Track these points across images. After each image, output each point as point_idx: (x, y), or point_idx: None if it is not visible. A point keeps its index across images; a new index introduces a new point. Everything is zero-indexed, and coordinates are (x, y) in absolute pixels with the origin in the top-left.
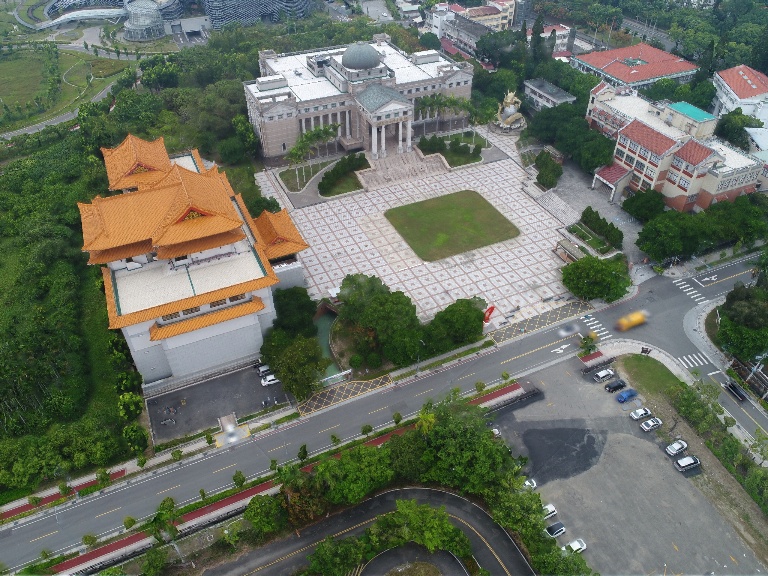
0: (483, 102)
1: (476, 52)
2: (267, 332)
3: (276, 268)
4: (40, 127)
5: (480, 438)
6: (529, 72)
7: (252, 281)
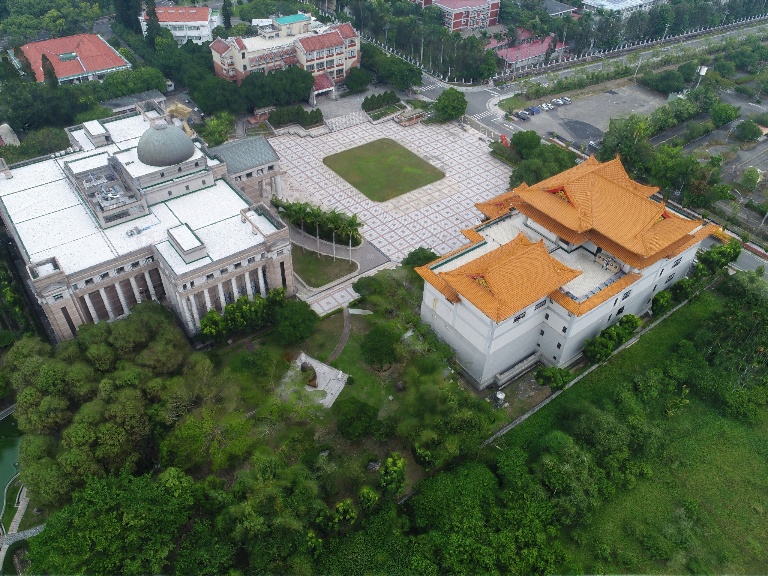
0: None
1: (19, 126)
2: None
3: None
4: None
5: (634, 117)
6: (71, 109)
7: None
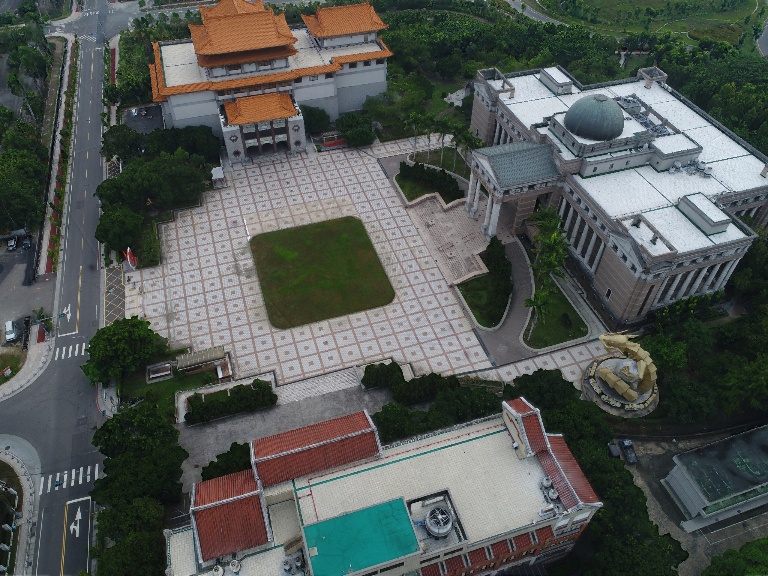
0: (663, 337)
1: None
2: None
3: (221, 117)
4: None
5: None
6: None
7: None
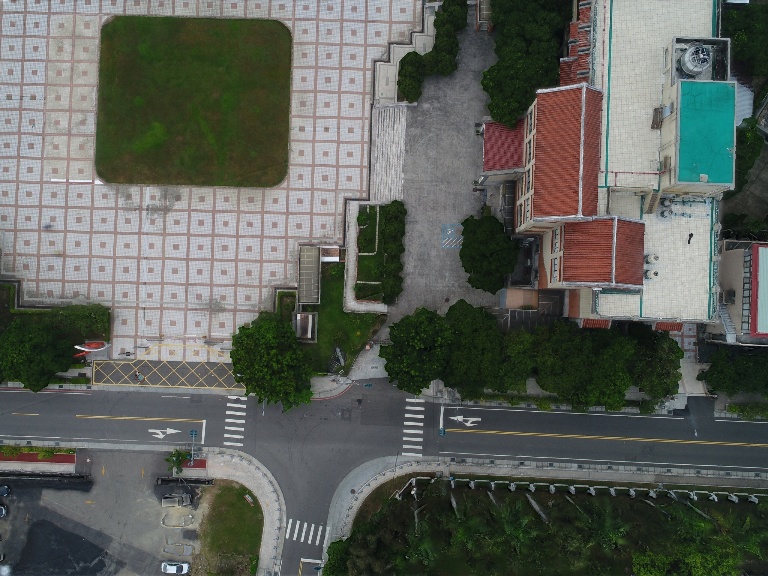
0: None
1: None
2: None
3: None
4: None
5: None
6: None
7: None
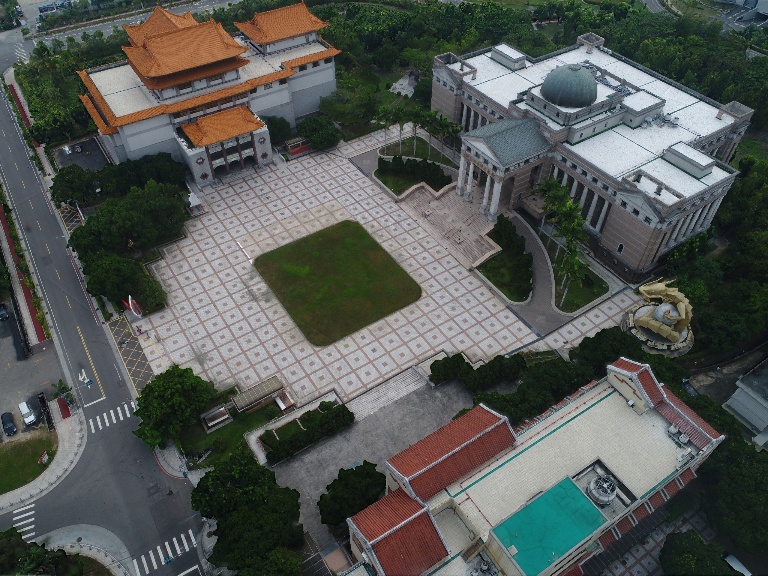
0: (681, 278)
1: None
2: (125, 162)
3: (181, 140)
4: None
5: None
6: None
7: (111, 112)
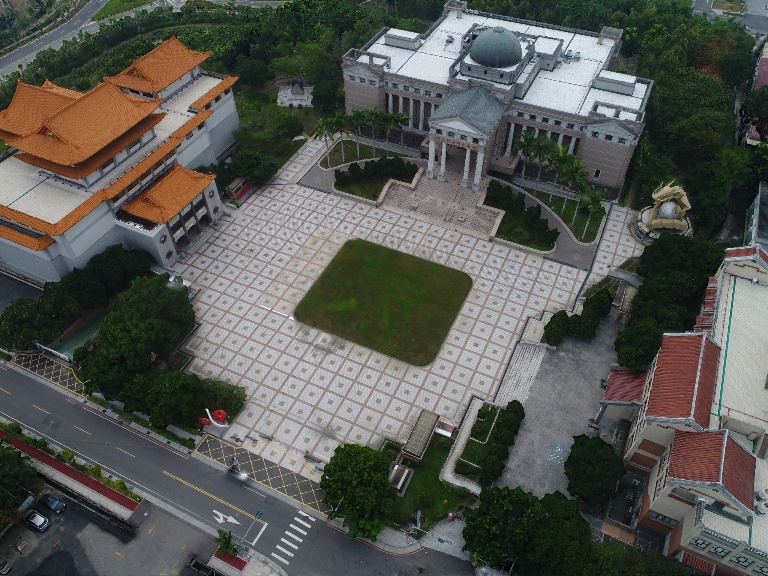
0: (655, 180)
1: (742, 107)
2: None
3: (130, 225)
4: (278, 5)
5: None
6: None
7: (41, 221)
